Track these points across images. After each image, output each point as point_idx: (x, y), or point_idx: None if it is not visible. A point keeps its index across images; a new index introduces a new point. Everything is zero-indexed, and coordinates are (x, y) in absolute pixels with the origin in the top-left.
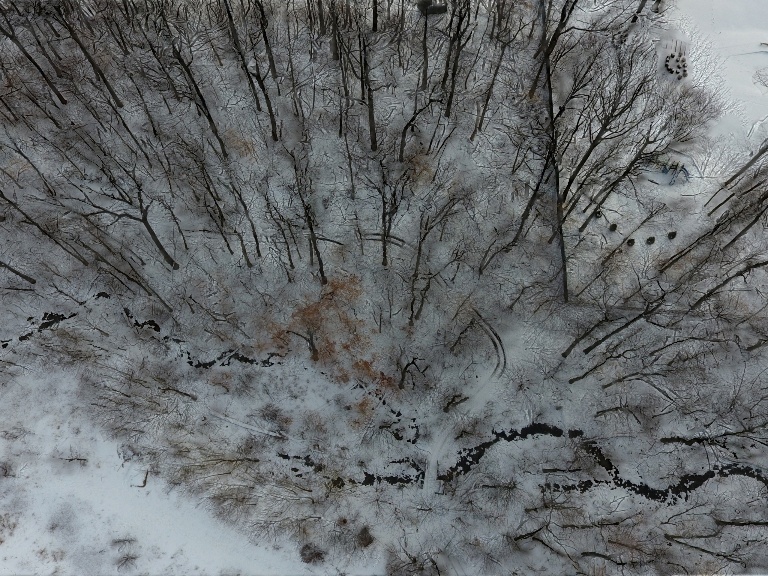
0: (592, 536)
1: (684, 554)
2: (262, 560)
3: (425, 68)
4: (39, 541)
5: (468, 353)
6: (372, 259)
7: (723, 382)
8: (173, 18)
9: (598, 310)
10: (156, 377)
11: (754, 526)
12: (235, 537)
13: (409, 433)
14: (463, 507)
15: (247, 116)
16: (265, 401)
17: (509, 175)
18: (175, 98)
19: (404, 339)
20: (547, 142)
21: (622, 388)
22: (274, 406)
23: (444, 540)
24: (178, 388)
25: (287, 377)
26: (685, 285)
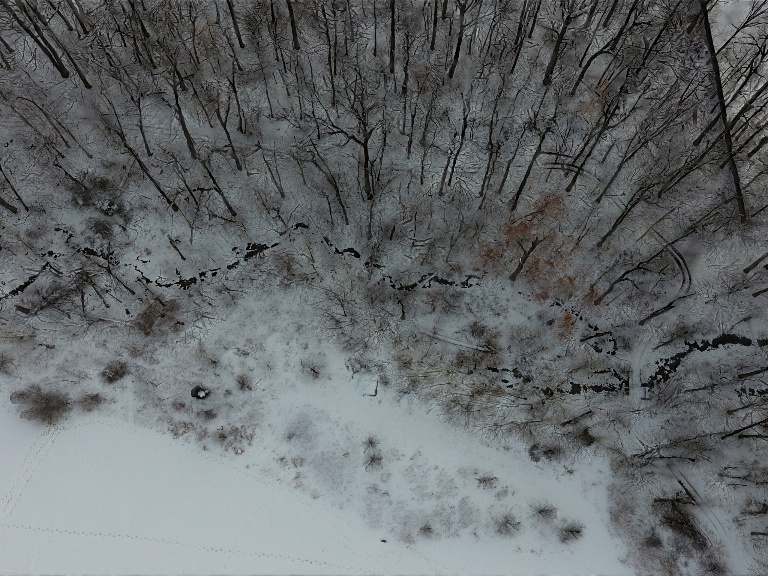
0: None
1: None
2: (495, 460)
3: (594, 4)
4: (277, 450)
5: (656, 271)
6: (556, 186)
7: None
8: None
9: None
10: (365, 299)
11: None
12: (467, 439)
13: (608, 346)
14: (669, 411)
15: (421, 55)
16: (470, 319)
17: (677, 105)
18: (350, 39)
19: (593, 259)
20: (709, 74)
21: None
22: (479, 323)
23: (655, 441)
24: (387, 308)
25: (487, 297)
26: None
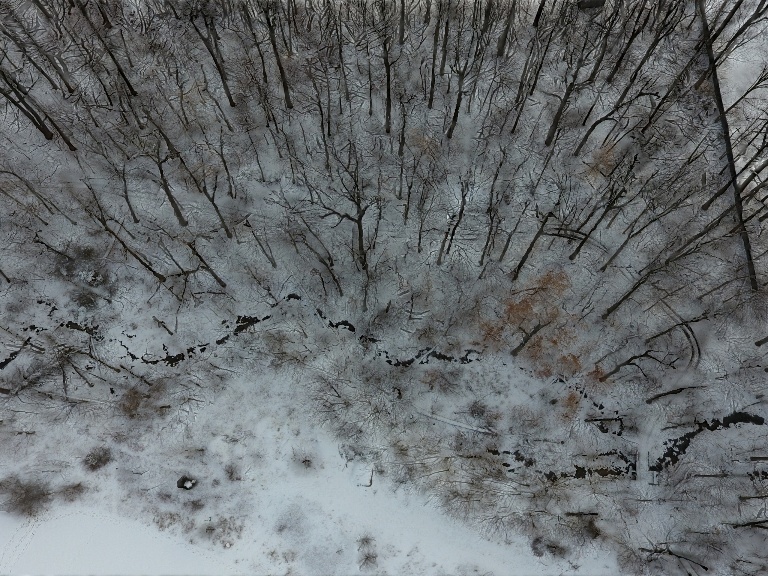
0: None
1: None
2: (496, 555)
3: (598, 62)
4: (268, 543)
5: (663, 344)
6: (559, 254)
7: None
8: None
9: None
10: (360, 377)
11: None
12: (467, 533)
13: (614, 425)
14: (678, 497)
15: (419, 114)
16: (470, 398)
17: None
18: (345, 98)
19: (598, 332)
20: (718, 133)
21: None
22: (479, 402)
23: (664, 530)
24: (383, 387)
25: (488, 373)
26: None
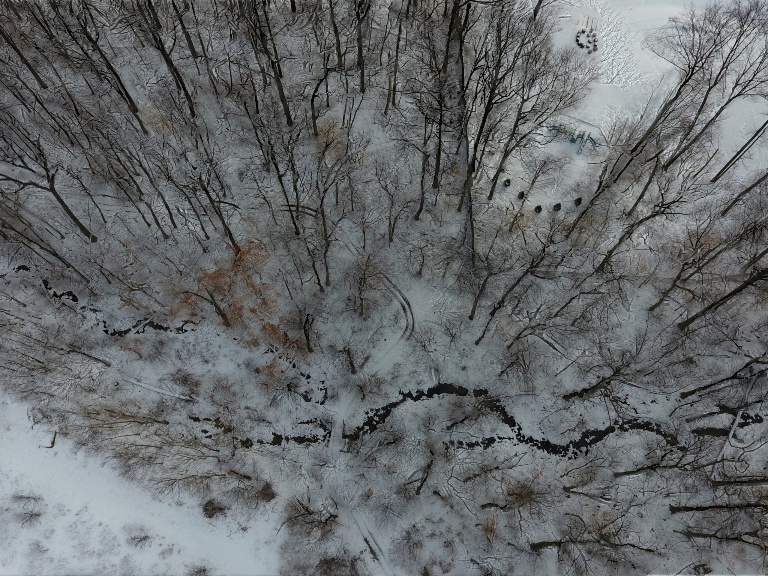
0: (492, 490)
1: (582, 505)
2: (165, 516)
3: (338, 45)
4: None
5: (377, 317)
6: (285, 229)
7: (626, 341)
8: (96, 2)
9: (505, 274)
10: None
11: (651, 478)
12: (139, 494)
13: (318, 395)
14: (367, 464)
15: (167, 95)
16: (177, 366)
17: (421, 147)
18: (98, 79)
19: (315, 305)
20: (459, 115)
21: (522, 346)
22: (186, 371)
23: (347, 496)
24: (92, 355)
25: (200, 343)
26: (590, 249)
